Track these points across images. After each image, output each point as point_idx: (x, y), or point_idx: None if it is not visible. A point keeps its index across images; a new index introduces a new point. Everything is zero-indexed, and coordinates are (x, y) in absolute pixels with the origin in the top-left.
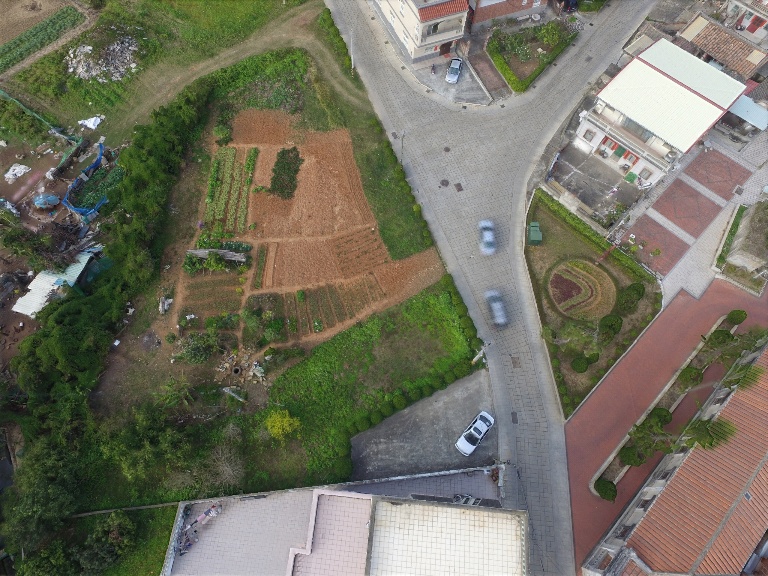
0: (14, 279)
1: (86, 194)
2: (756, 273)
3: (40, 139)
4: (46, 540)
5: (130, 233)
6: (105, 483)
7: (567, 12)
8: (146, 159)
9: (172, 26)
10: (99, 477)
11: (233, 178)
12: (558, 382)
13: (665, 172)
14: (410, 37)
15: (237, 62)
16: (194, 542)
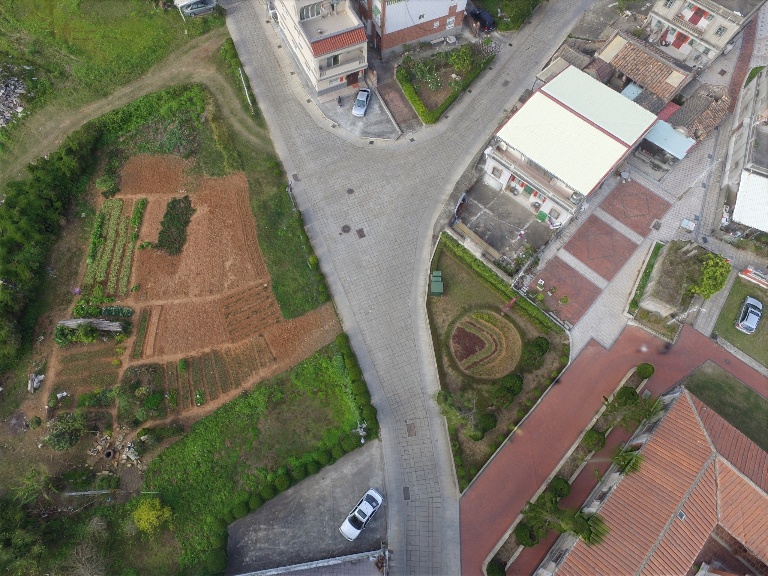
0: None
1: None
2: (670, 318)
3: None
4: None
5: None
6: None
7: (485, 32)
8: (18, 220)
9: (65, 63)
10: None
11: (118, 234)
12: (454, 451)
13: (571, 213)
14: (310, 70)
15: (132, 101)
16: None
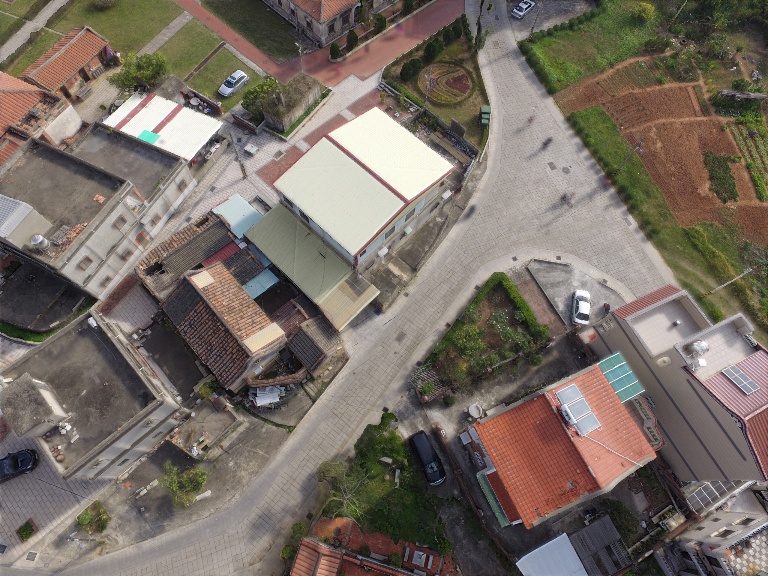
0: None
1: None
2: None
3: None
4: None
5: None
6: None
7: None
8: None
9: None
10: None
11: (766, 170)
12: None
13: None
14: None
15: None
16: None
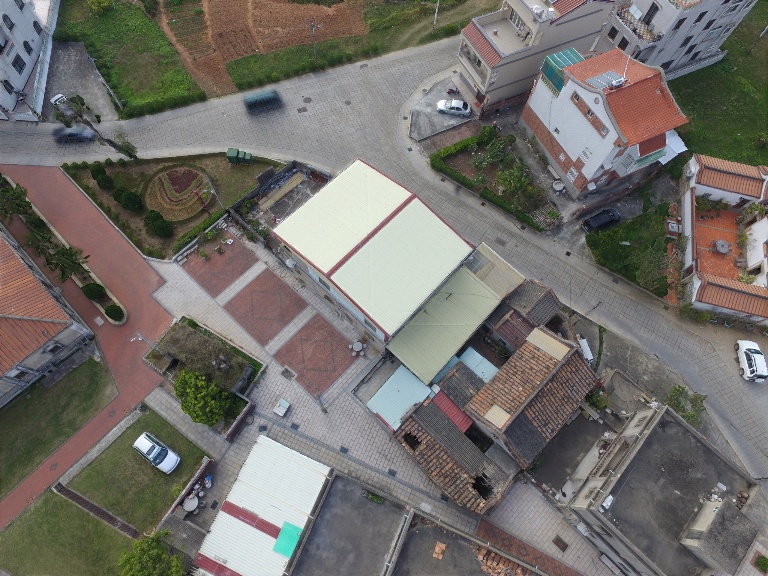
0: None
1: None
2: None
3: None
4: None
5: None
6: None
7: None
8: None
9: None
10: None
11: None
12: None
13: None
14: None
15: None
16: None
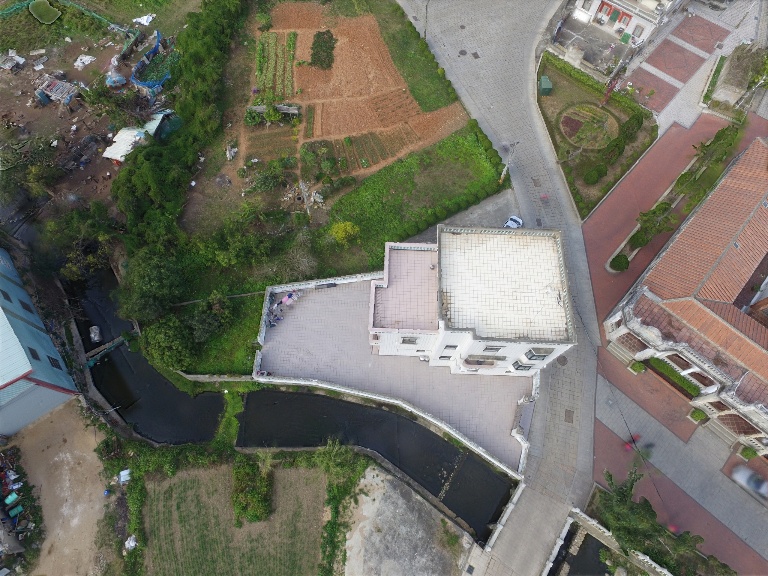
0: (97, 139)
1: (149, 74)
2: None
3: (101, 34)
4: (160, 314)
5: (197, 93)
6: (199, 283)
7: None
8: (202, 38)
9: None
10: (194, 278)
11: (277, 56)
12: (574, 194)
13: (655, 24)
14: None
15: None
16: (280, 319)
